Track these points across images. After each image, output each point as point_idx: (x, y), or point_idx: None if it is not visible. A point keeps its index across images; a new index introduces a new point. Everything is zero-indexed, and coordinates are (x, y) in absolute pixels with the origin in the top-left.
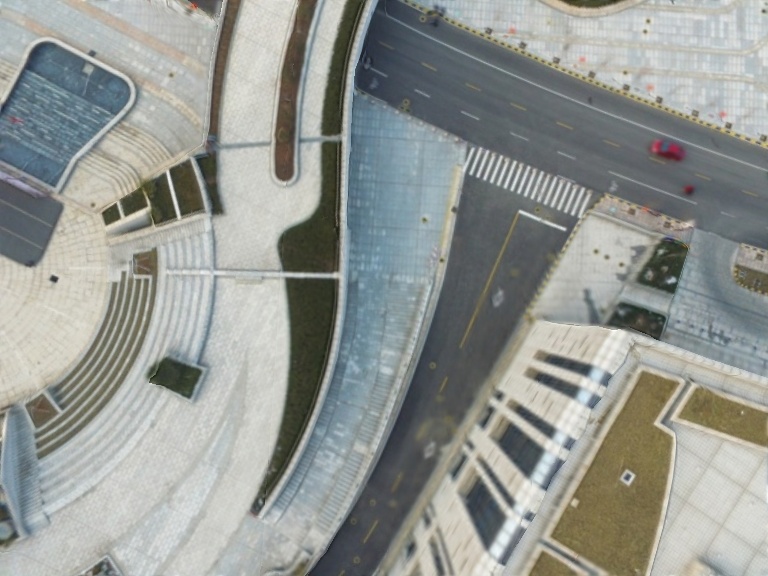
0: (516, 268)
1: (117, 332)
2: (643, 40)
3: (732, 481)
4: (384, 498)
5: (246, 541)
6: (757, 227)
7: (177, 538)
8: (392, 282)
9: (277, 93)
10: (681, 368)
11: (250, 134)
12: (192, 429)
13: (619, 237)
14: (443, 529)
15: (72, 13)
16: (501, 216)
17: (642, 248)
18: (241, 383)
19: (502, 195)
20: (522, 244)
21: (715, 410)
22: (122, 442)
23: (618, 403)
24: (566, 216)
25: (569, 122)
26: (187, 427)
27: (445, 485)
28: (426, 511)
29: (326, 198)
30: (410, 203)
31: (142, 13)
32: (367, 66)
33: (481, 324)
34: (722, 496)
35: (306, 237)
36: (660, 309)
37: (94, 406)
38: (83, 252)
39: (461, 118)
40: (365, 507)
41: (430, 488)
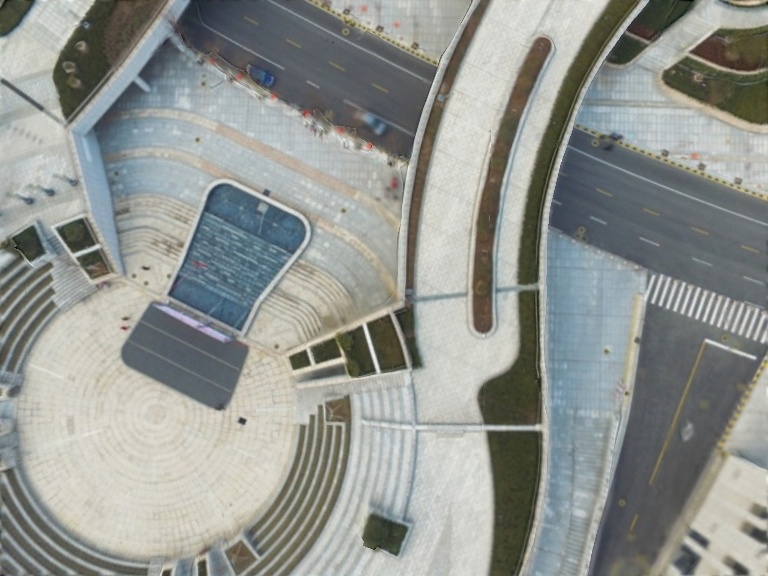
0: (705, 400)
1: (309, 477)
2: None
3: None
4: None
5: None
6: None
7: None
8: (577, 417)
9: (472, 243)
10: None
11: (446, 285)
12: None
13: None
14: None
15: (245, 153)
16: (687, 346)
17: None
18: (446, 538)
19: (687, 324)
20: (710, 374)
21: None
22: None
23: None
24: (755, 344)
25: (755, 245)
26: None
27: None
28: None
29: (526, 349)
30: (591, 334)
31: (313, 150)
32: None
33: (671, 459)
34: None
35: (507, 390)
36: None
37: (294, 555)
38: (269, 394)
39: (640, 244)
40: None
41: None
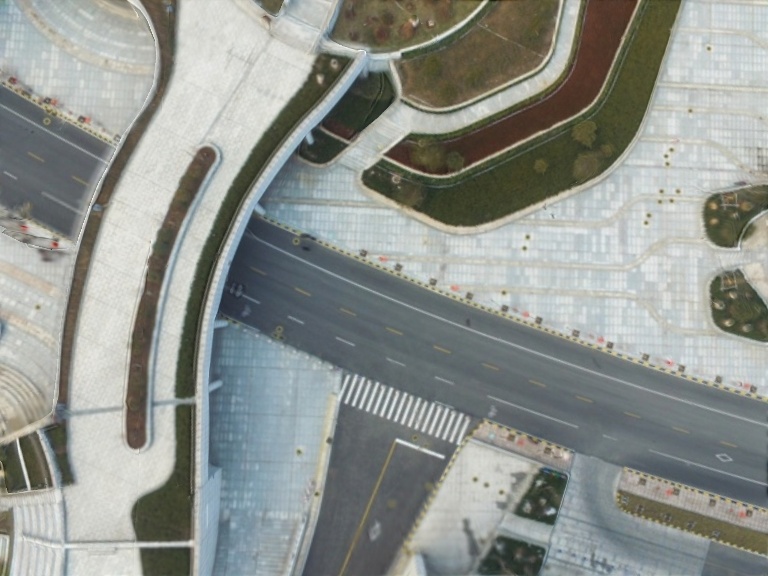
0: (393, 499)
1: None
2: (522, 257)
3: None
4: None
5: None
6: (640, 450)
7: None
8: (265, 520)
9: (128, 357)
10: None
11: (101, 399)
12: None
13: (499, 464)
14: None
15: None
16: (378, 446)
17: (522, 475)
18: None
19: (378, 424)
20: (399, 474)
21: None
22: None
23: None
24: (445, 443)
25: (447, 346)
26: None
27: None
28: None
29: (180, 464)
30: (284, 435)
31: (7, 244)
32: (239, 293)
33: (358, 559)
34: None
35: (160, 506)
36: (540, 539)
37: None
38: None
39: (336, 344)
40: None
41: None
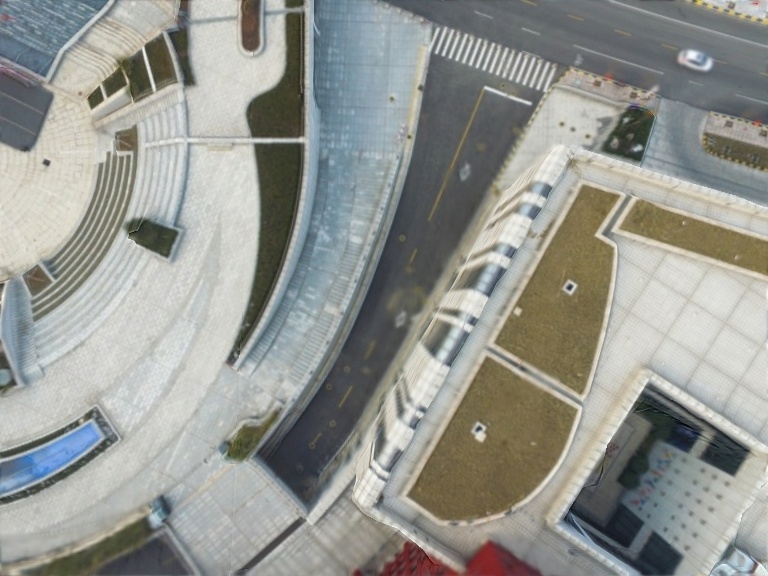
0: (483, 143)
1: (103, 207)
2: None
3: (675, 292)
4: (358, 365)
5: (223, 391)
6: (726, 94)
7: (159, 389)
8: (361, 158)
9: None
10: (623, 184)
11: (218, 9)
12: (171, 287)
13: (585, 109)
14: (406, 373)
15: None
16: (467, 93)
17: (608, 119)
18: (215, 244)
19: (468, 72)
20: (488, 119)
21: (656, 220)
22: (108, 301)
23: (559, 216)
24: (532, 91)
25: None
26: (166, 286)
27: (414, 347)
28: (397, 374)
29: (291, 66)
30: (378, 83)
31: None
32: None
33: (449, 197)
34: (665, 307)
35: (273, 104)
36: None
37: (83, 273)
38: (72, 137)
39: None
40: (340, 373)
41: (402, 354)
